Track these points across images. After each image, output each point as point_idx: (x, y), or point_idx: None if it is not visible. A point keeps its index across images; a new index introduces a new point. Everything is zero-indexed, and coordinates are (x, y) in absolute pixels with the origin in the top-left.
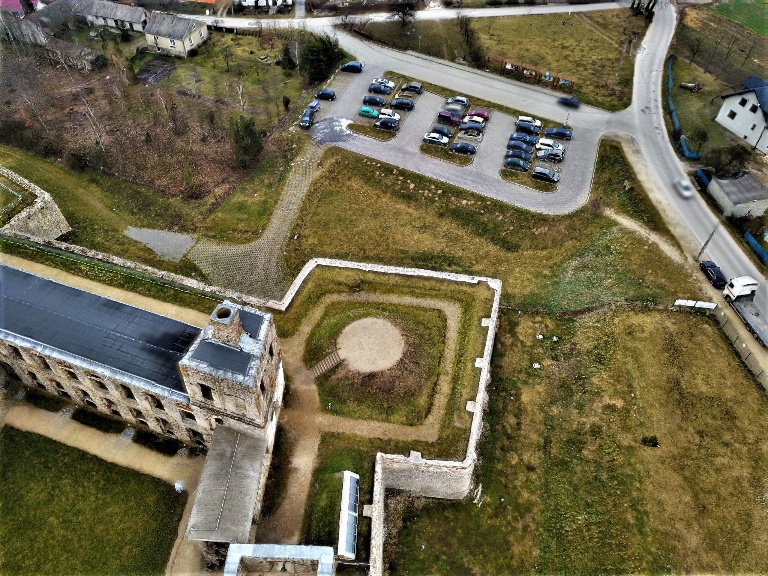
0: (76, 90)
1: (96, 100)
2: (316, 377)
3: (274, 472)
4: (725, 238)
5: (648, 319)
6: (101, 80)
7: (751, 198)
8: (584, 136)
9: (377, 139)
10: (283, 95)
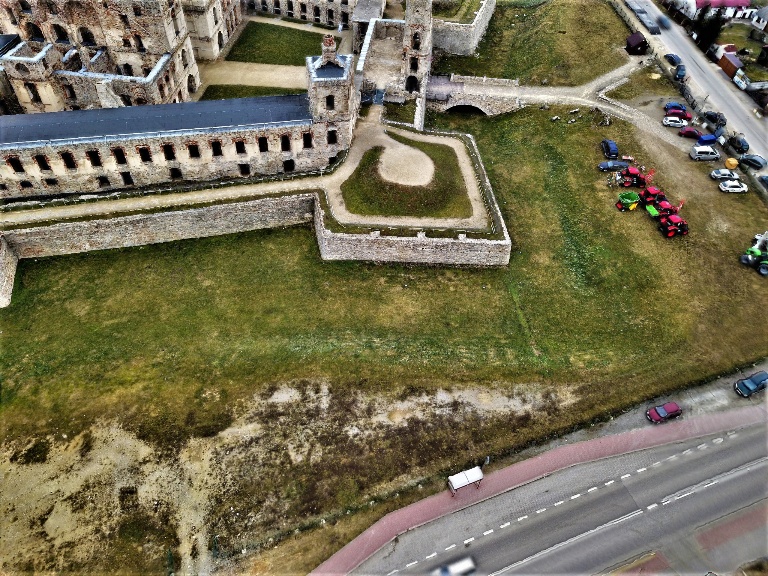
0: None
1: None
2: (401, 2)
3: None
4: None
5: (574, 1)
6: None
7: None
8: None
9: None
10: None
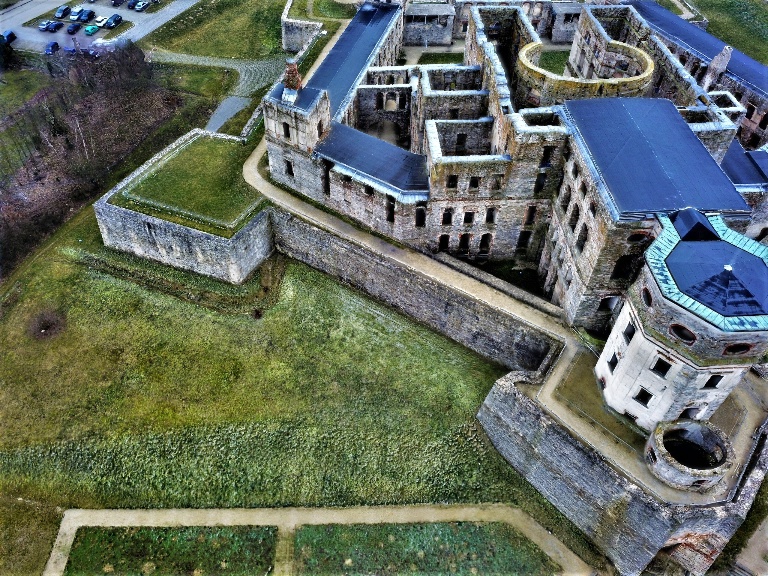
0: None
1: None
2: None
3: None
4: None
5: None
6: None
7: None
8: None
9: (131, 28)
10: (47, 63)
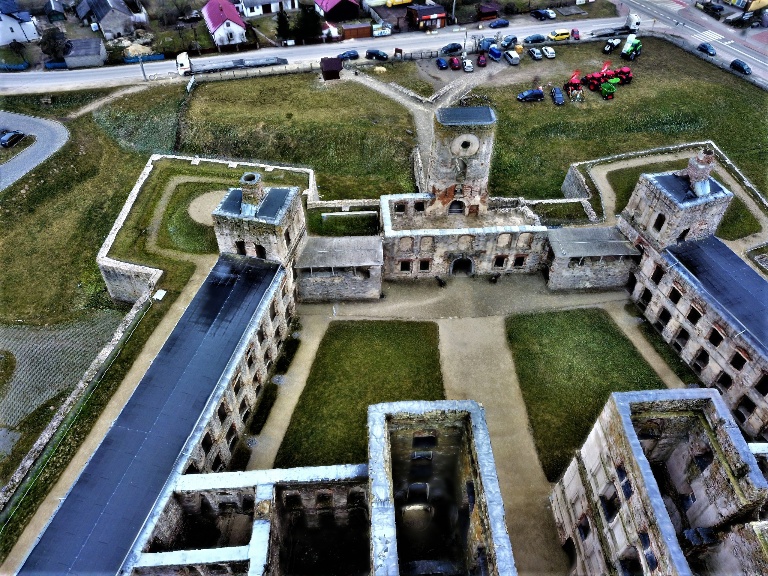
0: None
1: None
2: None
3: None
4: (127, 68)
5: (197, 105)
6: None
7: (97, 46)
8: None
9: None
10: None
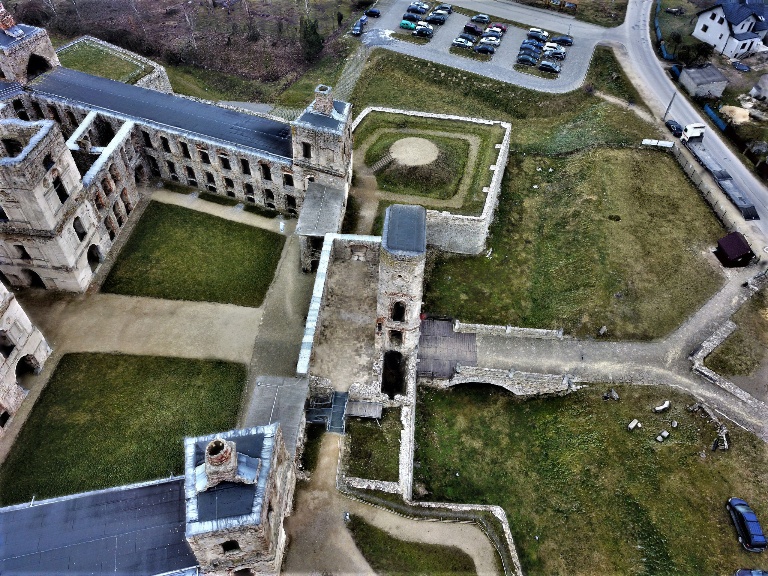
0: (166, 10)
1: (183, 17)
2: (375, 171)
3: (348, 217)
4: (688, 108)
5: (621, 153)
6: (185, 4)
7: (711, 81)
8: (583, 43)
9: (415, 43)
10: (338, 12)
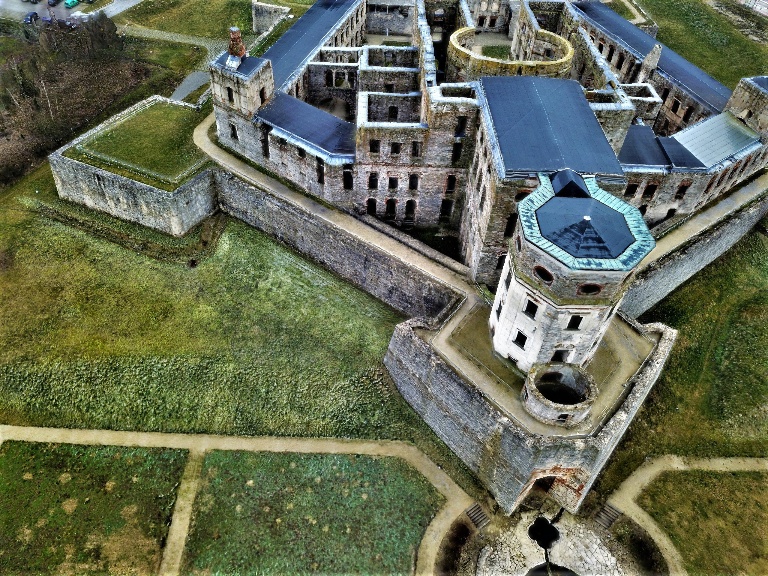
0: None
1: None
2: None
3: None
4: None
5: None
6: None
7: None
8: None
9: (109, 3)
10: (24, 30)
